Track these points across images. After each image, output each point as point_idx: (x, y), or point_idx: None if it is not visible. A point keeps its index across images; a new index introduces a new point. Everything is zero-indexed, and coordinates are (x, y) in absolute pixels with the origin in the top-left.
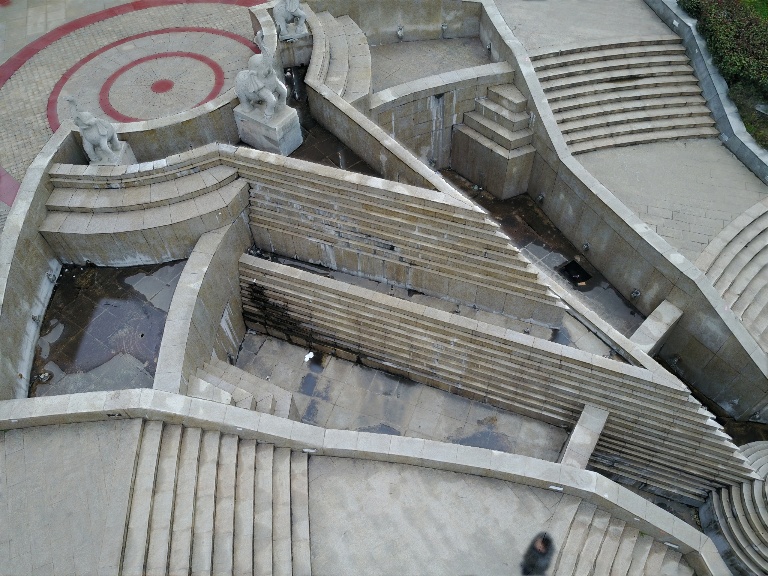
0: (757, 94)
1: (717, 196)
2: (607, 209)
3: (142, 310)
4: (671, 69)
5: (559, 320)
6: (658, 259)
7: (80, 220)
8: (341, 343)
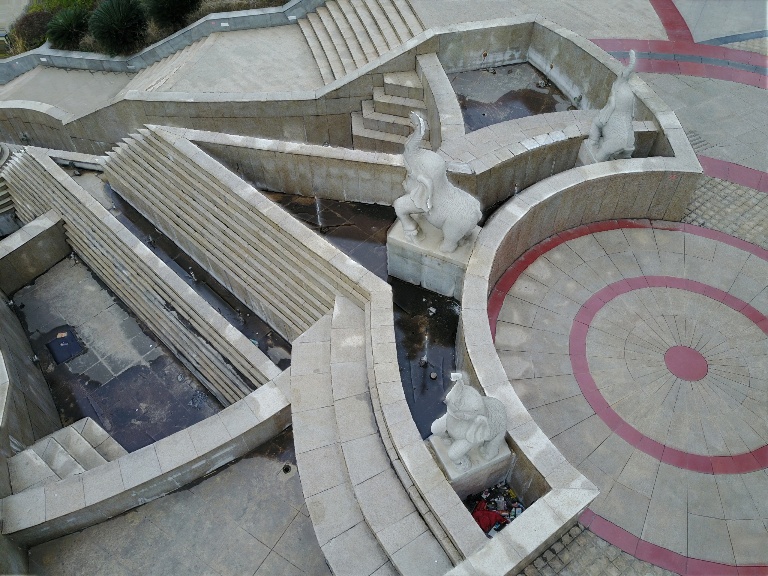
0: None
1: None
2: None
3: None
4: None
5: None
6: None
7: (588, 119)
8: None
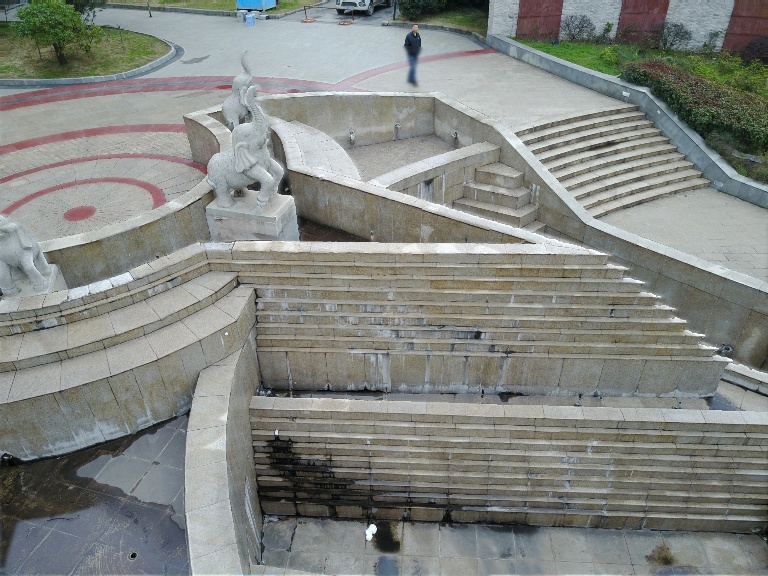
0: (733, 139)
1: (752, 233)
2: (666, 260)
3: (121, 513)
4: (640, 132)
5: (715, 382)
6: (755, 297)
7: None
8: (420, 496)
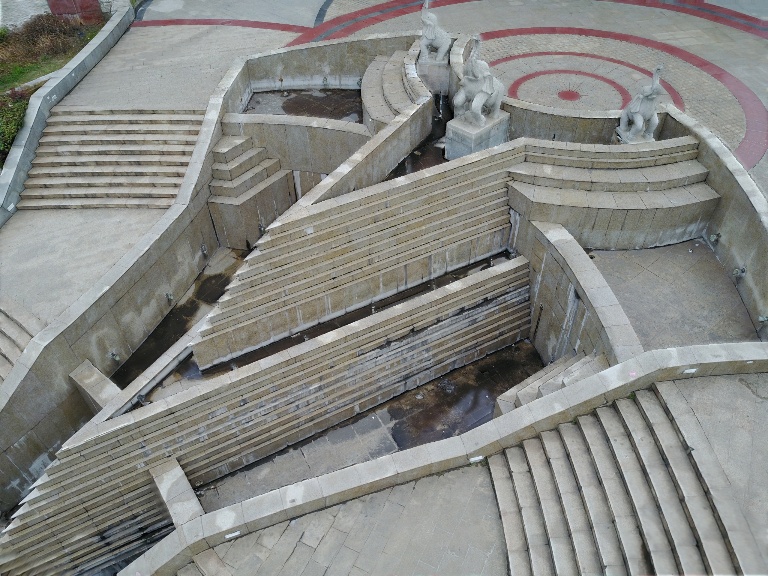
0: None
1: None
2: None
3: None
4: None
5: (198, 357)
6: None
7: (381, 66)
8: None
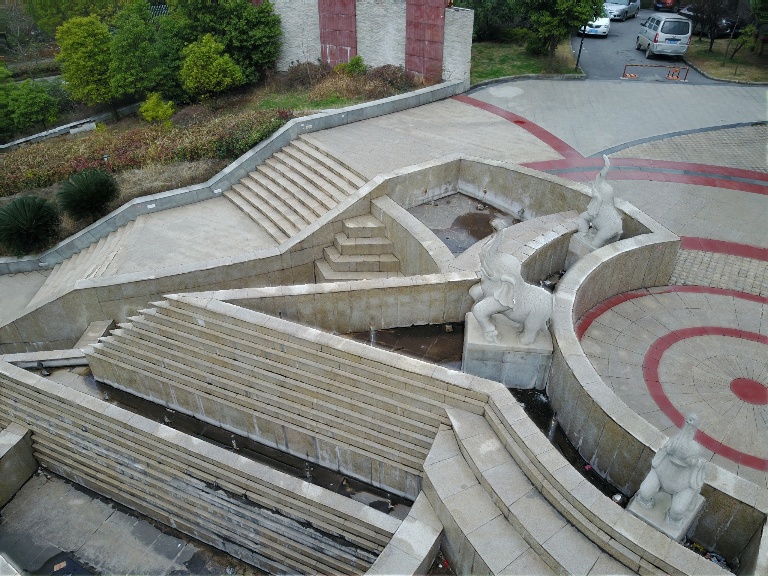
0: None
1: None
2: None
3: None
4: None
5: None
6: None
7: None
8: None
